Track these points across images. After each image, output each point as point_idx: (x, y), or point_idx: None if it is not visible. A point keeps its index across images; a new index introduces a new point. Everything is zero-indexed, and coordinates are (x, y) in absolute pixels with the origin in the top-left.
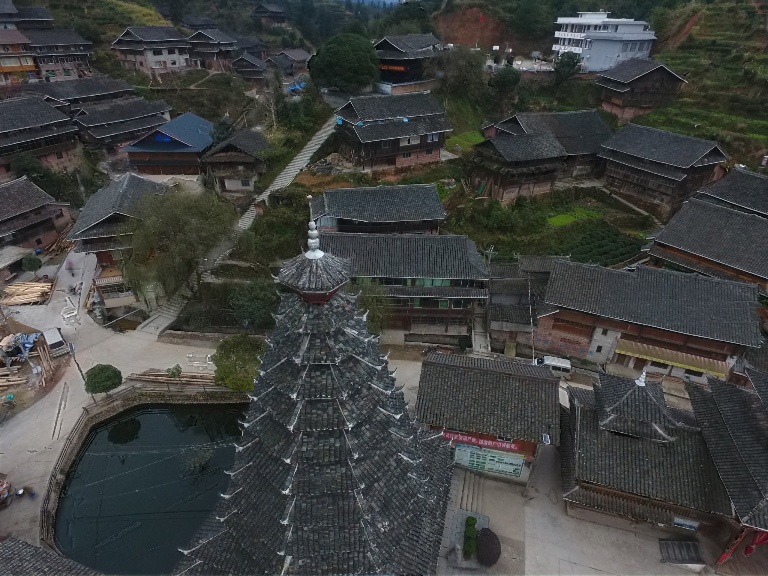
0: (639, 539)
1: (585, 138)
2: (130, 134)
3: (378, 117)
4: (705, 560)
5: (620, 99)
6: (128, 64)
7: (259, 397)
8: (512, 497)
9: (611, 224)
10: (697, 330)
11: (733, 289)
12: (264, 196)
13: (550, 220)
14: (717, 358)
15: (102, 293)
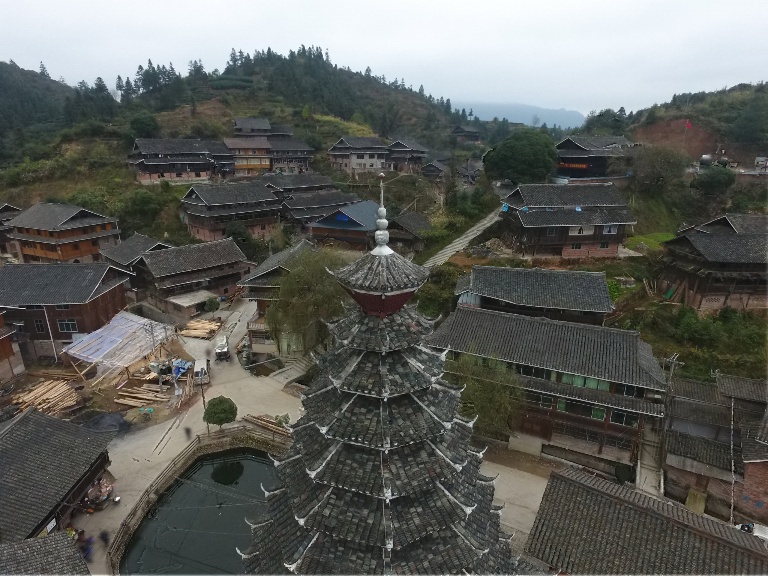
0: None
1: None
2: None
3: (546, 204)
4: None
5: None
6: (336, 165)
7: (296, 429)
8: None
9: None
10: None
11: None
12: None
13: None
14: None
15: (252, 337)
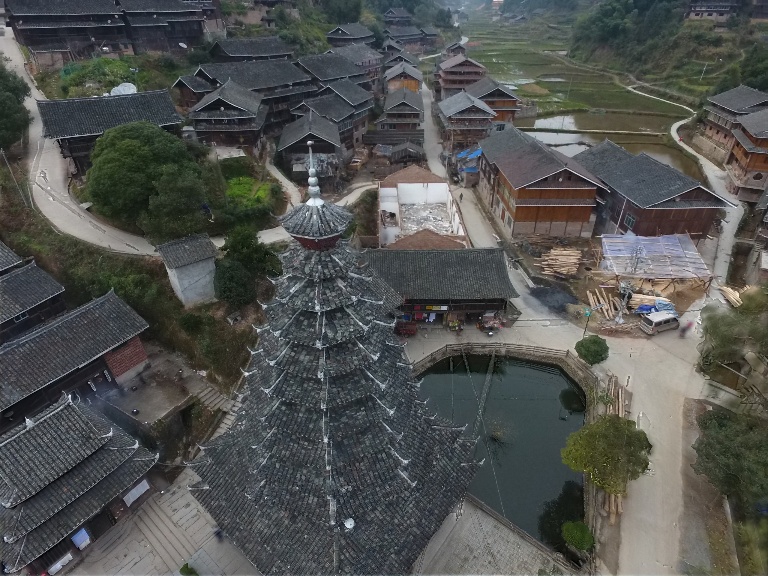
0: None
1: None
2: None
3: None
4: None
5: None
6: None
7: None
8: None
9: None
10: None
11: None
12: None
13: None
14: None
15: None
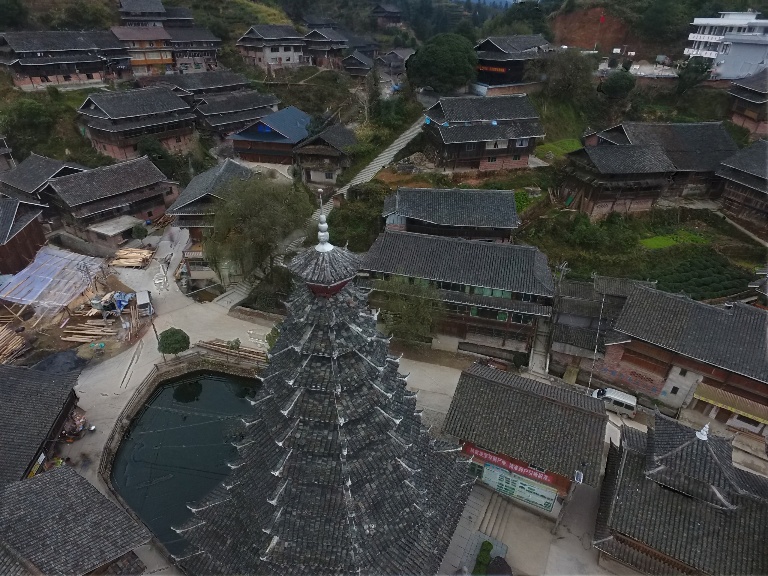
0: None
1: (703, 153)
2: (241, 124)
3: (465, 119)
4: None
5: (755, 111)
6: (249, 60)
7: (266, 378)
8: (539, 531)
9: (719, 253)
10: None
11: None
12: (344, 190)
13: (645, 241)
14: None
15: (189, 265)
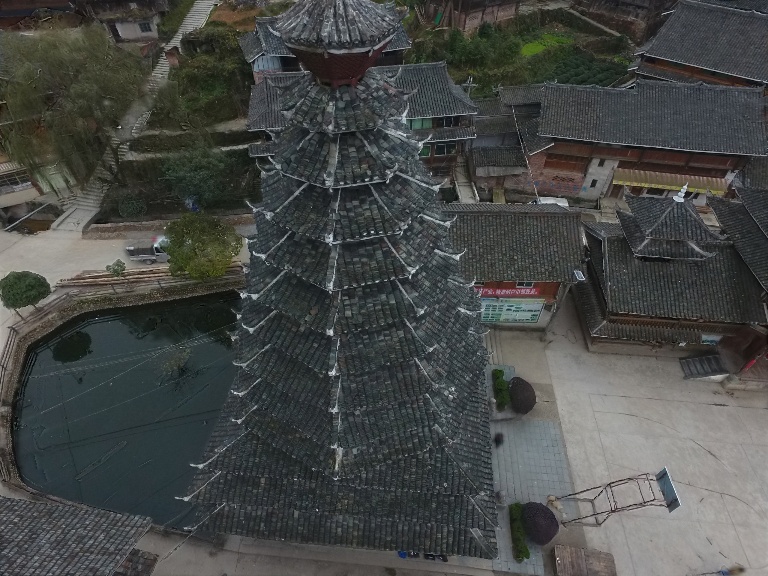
0: (661, 362)
1: None
2: None
3: None
4: (728, 370)
5: None
6: None
7: (268, 253)
8: (531, 344)
9: (584, 49)
10: (703, 145)
11: (738, 96)
12: (174, 44)
13: None
14: (716, 175)
15: None
